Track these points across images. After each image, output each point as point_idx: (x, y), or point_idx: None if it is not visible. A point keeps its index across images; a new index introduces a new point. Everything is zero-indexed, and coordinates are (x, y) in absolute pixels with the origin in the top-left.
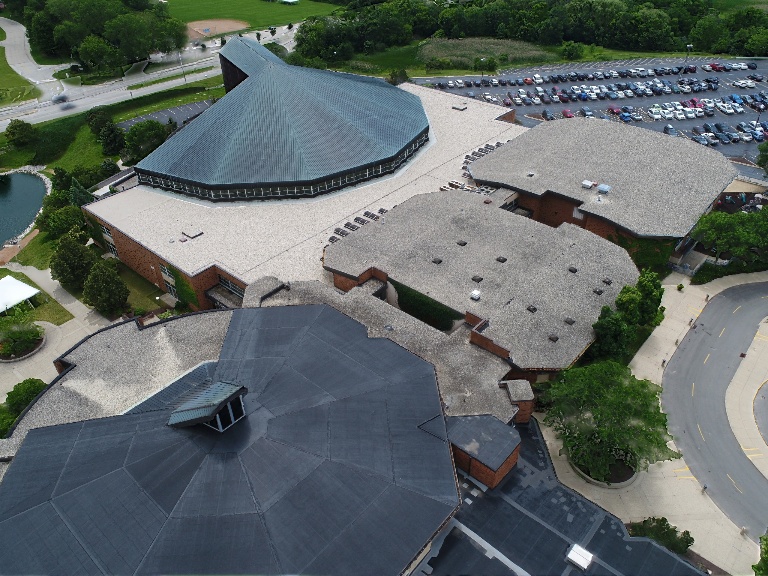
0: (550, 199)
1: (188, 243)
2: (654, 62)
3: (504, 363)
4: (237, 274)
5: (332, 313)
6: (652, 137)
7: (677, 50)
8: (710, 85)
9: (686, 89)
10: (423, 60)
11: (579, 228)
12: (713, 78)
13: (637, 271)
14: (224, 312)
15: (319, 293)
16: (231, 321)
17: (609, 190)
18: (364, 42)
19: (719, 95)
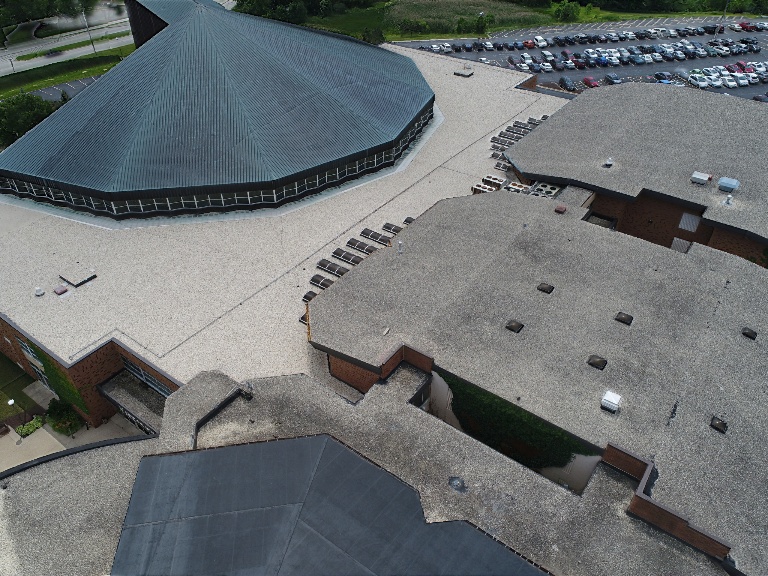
0: (642, 201)
1: (68, 296)
2: (670, 22)
3: (715, 568)
4: (153, 357)
5: (342, 459)
6: (748, 107)
7: (688, 10)
8: (751, 46)
9: (724, 51)
10: (393, 23)
11: (722, 252)
12: (751, 38)
13: None
14: (126, 446)
15: (308, 403)
16: (132, 496)
17: None
18: (319, 2)
19: (765, 58)
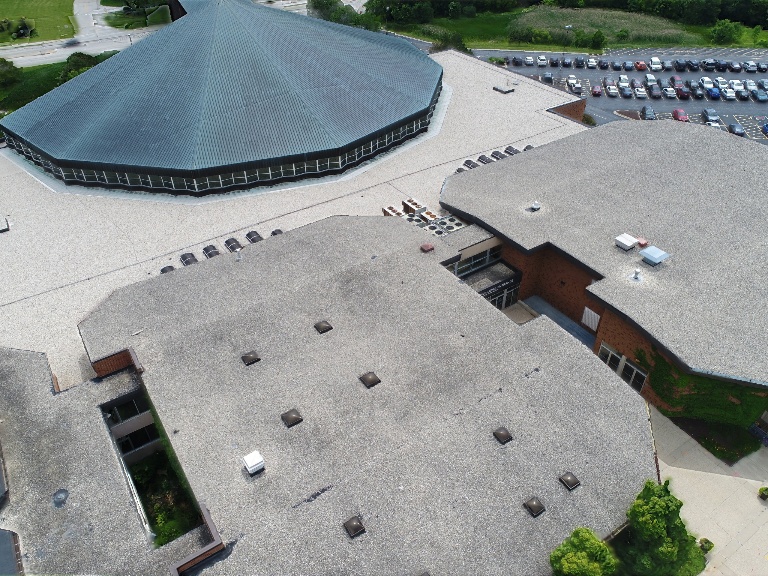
0: (555, 257)
1: None
2: None
3: None
4: None
5: None
6: None
7: None
8: None
9: None
10: None
11: (566, 333)
12: None
13: (652, 464)
14: None
15: (21, 381)
16: None
17: (665, 259)
18: (448, 3)
19: None
